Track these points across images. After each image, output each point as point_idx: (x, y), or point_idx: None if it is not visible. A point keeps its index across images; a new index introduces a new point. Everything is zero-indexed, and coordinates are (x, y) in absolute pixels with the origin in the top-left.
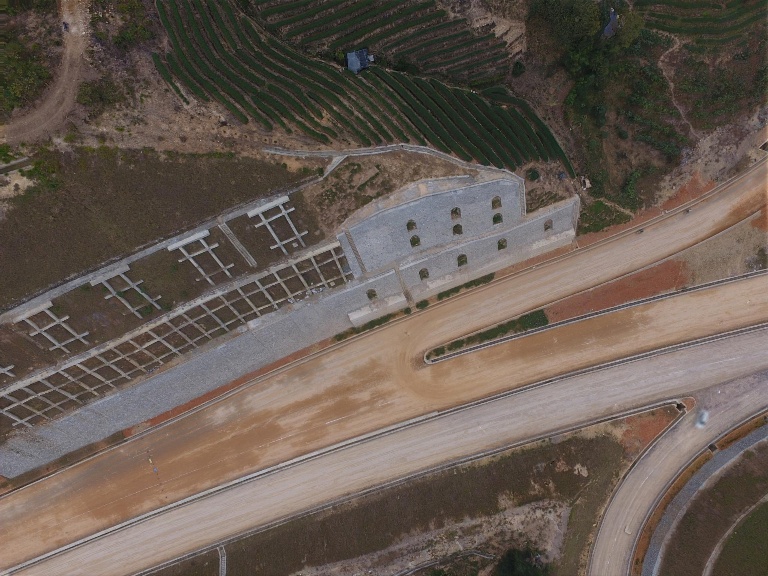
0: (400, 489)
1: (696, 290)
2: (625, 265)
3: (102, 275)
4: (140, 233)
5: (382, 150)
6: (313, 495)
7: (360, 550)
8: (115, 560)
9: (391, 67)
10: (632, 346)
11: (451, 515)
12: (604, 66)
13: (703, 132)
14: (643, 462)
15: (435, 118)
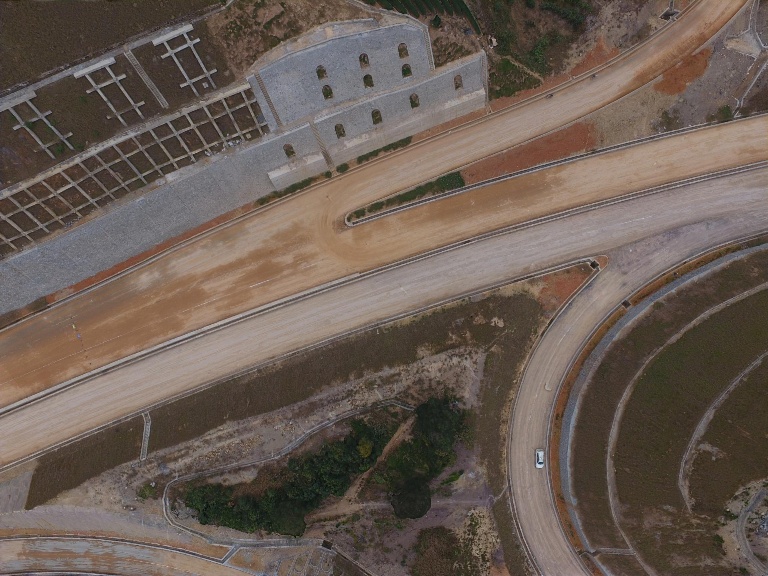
0: (324, 350)
1: (605, 152)
2: (537, 128)
3: (8, 101)
4: (45, 57)
5: None
6: (238, 359)
7: (281, 403)
8: (39, 430)
9: None
10: (546, 207)
11: (371, 367)
12: None
13: None
14: (560, 320)
15: None
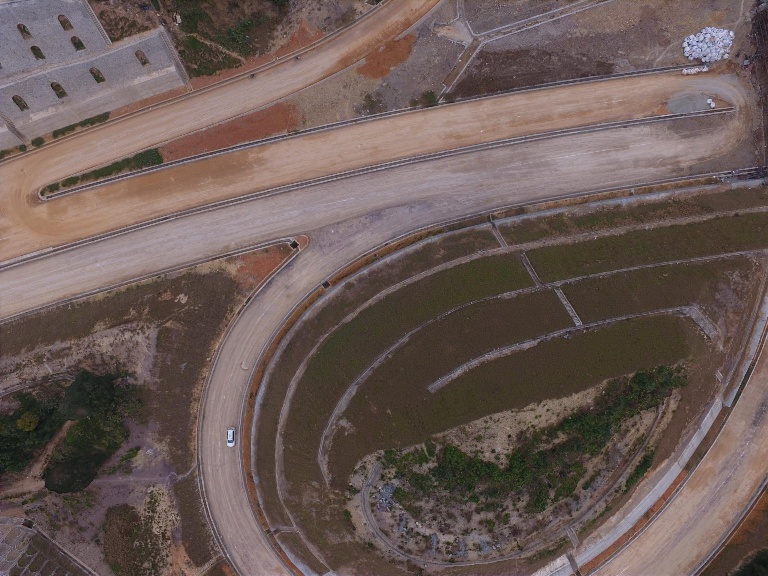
0: (13, 325)
1: (307, 133)
2: (238, 108)
3: None
4: None
5: None
6: None
7: None
8: None
9: None
10: (248, 186)
11: (45, 340)
12: None
13: None
14: (259, 299)
15: None
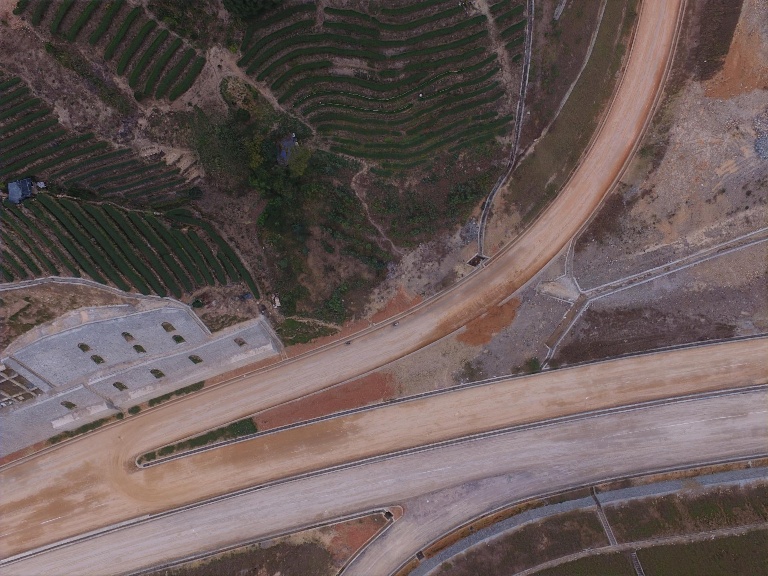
0: None
1: (404, 401)
2: (333, 376)
3: None
4: None
5: (29, 284)
6: None
7: None
8: None
9: (65, 192)
10: (342, 454)
11: None
12: (286, 190)
13: (405, 249)
14: (352, 568)
15: (98, 247)
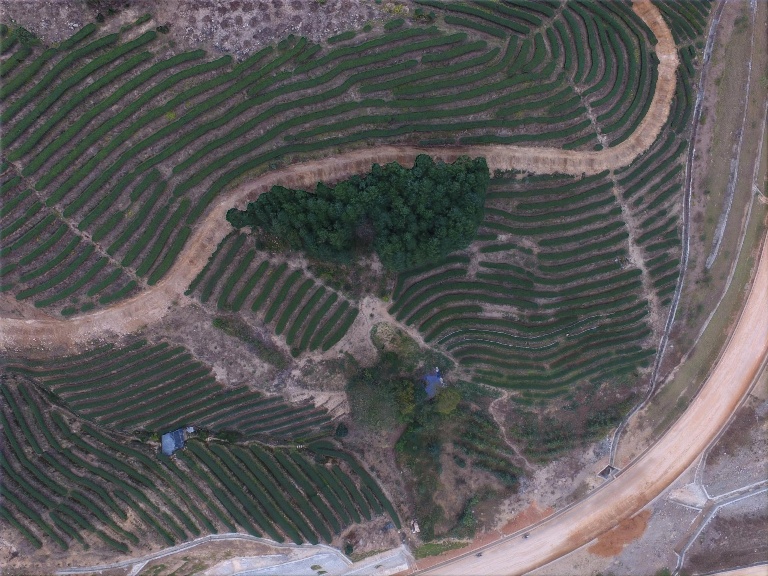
0: None
1: None
2: None
3: None
4: None
5: (188, 545)
6: None
7: None
8: None
9: (213, 434)
10: None
11: None
12: (429, 423)
13: (538, 466)
14: None
15: (250, 496)
